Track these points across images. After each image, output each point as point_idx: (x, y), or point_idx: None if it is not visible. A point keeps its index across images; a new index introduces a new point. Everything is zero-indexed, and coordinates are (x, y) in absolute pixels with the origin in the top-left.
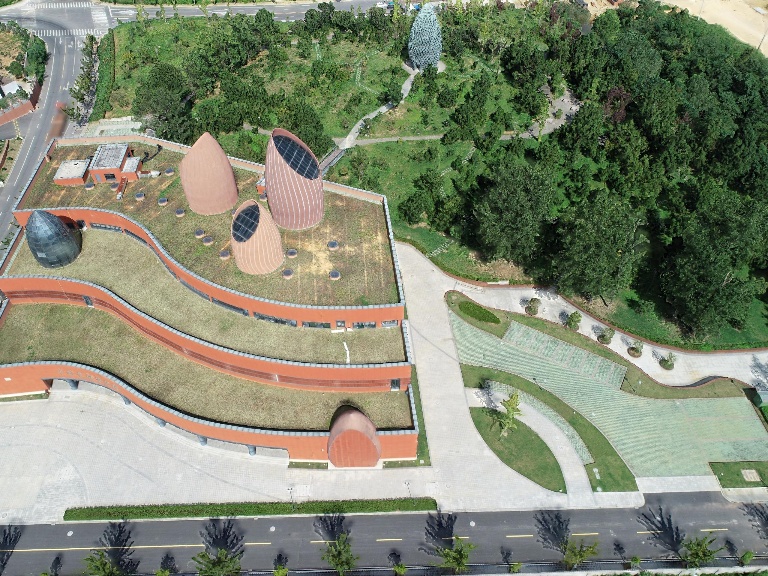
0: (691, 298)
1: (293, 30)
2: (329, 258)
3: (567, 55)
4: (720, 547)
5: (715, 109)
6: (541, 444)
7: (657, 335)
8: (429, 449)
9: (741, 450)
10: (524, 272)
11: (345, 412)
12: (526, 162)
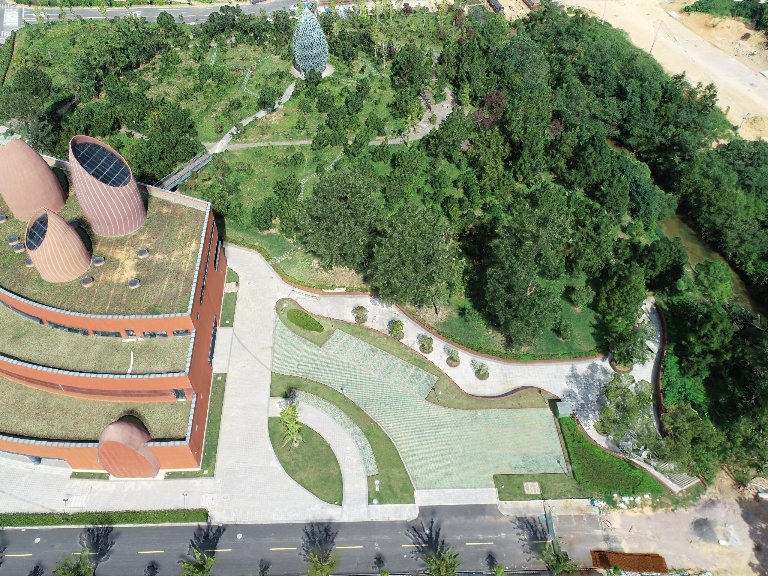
0: (501, 308)
1: (196, 33)
2: (135, 266)
3: (453, 60)
4: (481, 561)
5: (598, 115)
6: (329, 455)
7: (480, 344)
8: (216, 460)
9: (529, 462)
10: (363, 279)
11: None
12: (391, 168)
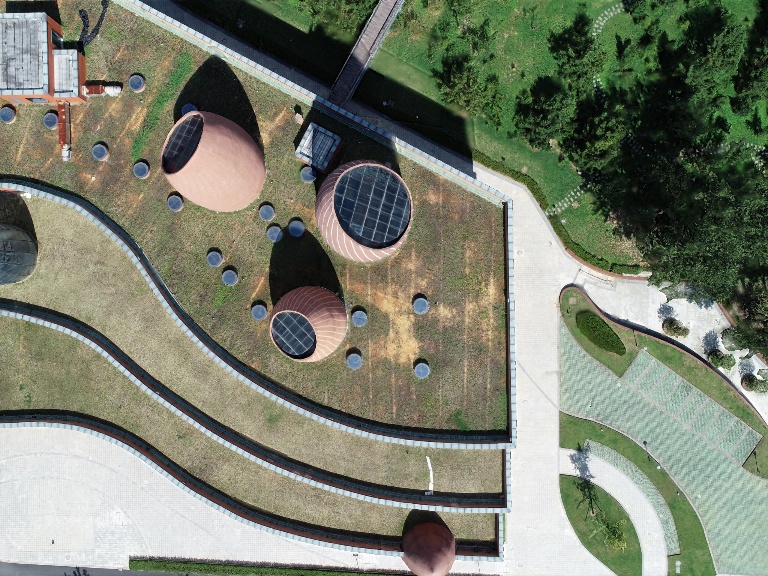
0: None
1: None
2: (414, 330)
3: None
4: None
5: None
6: (629, 529)
7: None
8: (506, 523)
9: None
10: None
11: (425, 558)
12: (758, 5)
